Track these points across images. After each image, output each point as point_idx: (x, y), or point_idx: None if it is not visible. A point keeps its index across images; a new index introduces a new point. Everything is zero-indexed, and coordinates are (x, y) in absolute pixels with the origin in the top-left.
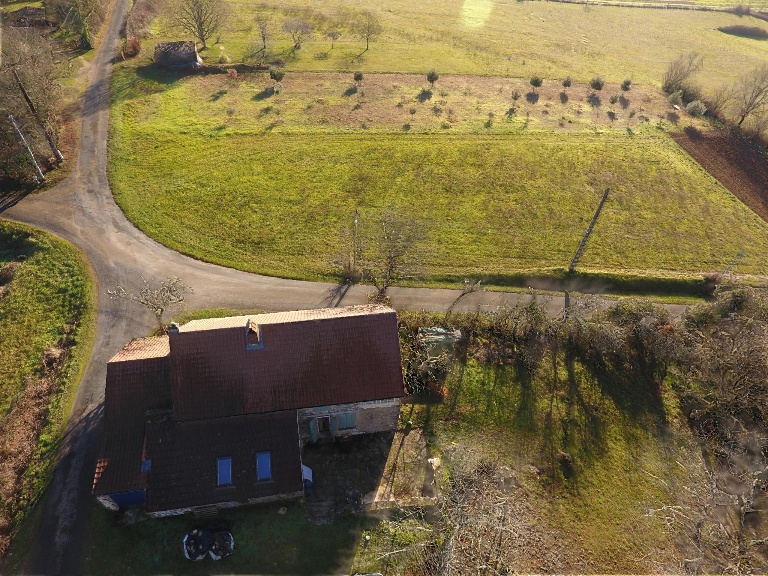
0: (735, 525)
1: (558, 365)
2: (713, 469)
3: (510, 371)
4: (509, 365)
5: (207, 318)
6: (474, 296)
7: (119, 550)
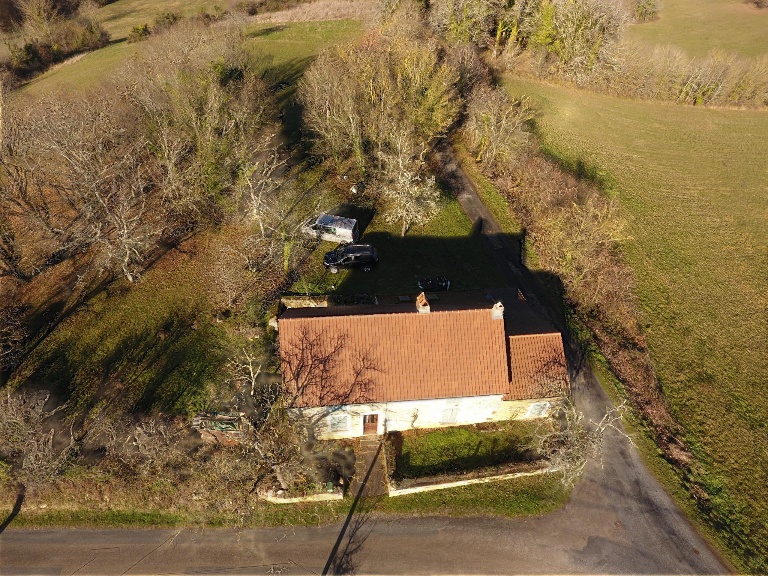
0: (74, 300)
1: (93, 420)
2: (42, 336)
3: (156, 408)
4: (152, 415)
5: (522, 497)
6: (113, 573)
7: (490, 287)
